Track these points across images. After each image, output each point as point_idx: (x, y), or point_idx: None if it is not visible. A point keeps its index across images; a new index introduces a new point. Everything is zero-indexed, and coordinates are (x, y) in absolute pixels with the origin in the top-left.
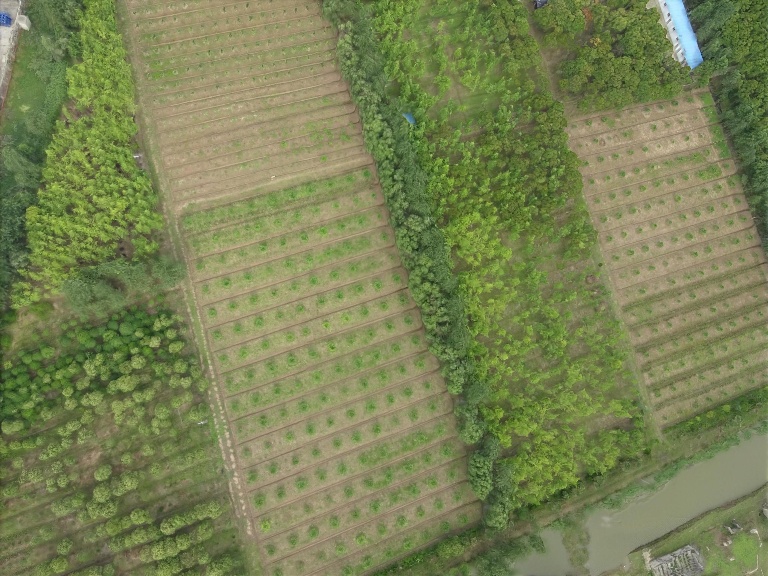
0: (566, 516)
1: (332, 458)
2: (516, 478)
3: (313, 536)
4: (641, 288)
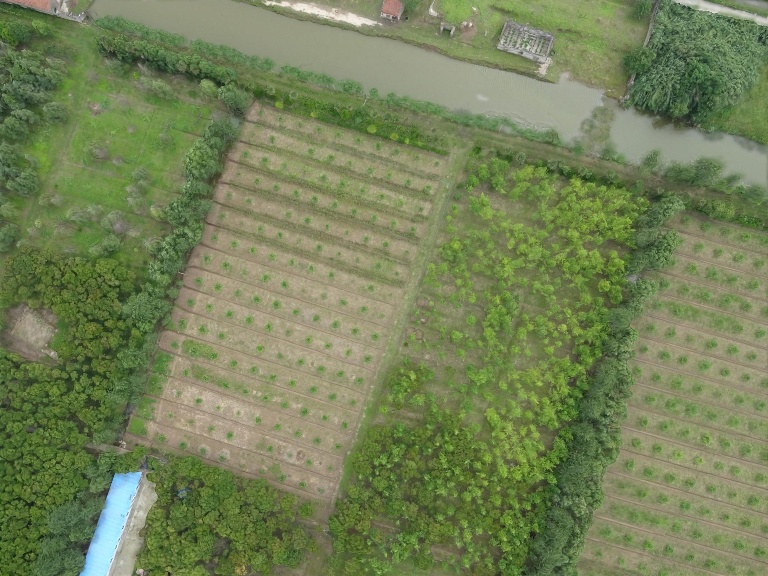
0: (592, 155)
1: (761, 348)
2: None
3: None
4: (368, 292)
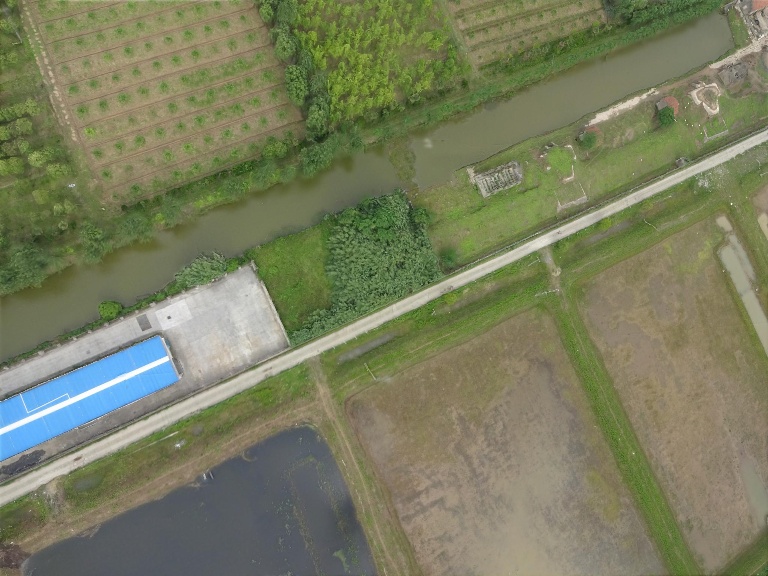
0: (391, 137)
1: (153, 80)
2: (333, 91)
3: (138, 141)
4: None
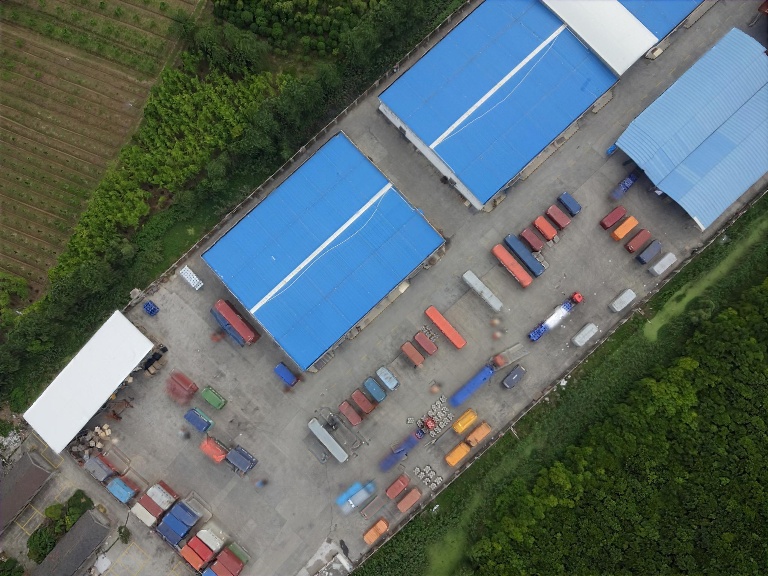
0: None
1: None
2: None
3: None
4: None
